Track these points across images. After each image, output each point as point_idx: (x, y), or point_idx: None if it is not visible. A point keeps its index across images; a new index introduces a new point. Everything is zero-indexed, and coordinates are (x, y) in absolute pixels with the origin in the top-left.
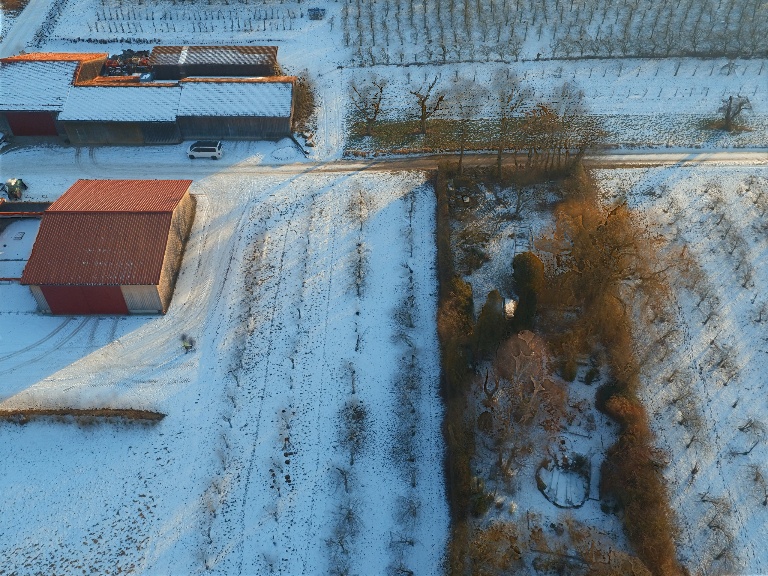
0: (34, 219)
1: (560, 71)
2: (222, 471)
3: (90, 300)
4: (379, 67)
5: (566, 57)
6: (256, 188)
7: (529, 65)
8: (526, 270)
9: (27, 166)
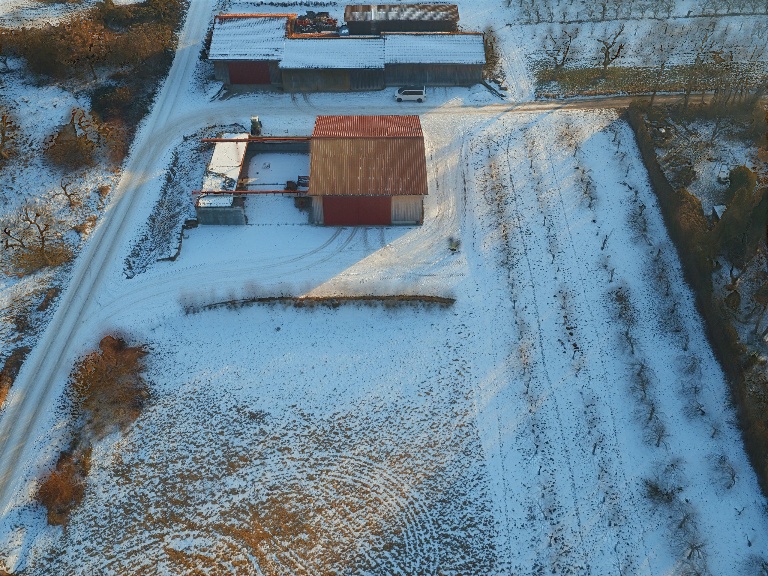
0: (273, 152)
1: (714, 25)
2: (518, 341)
3: (361, 211)
4: (544, 24)
5: (713, 14)
6: (467, 124)
7: (681, 21)
8: (744, 181)
9: (252, 109)
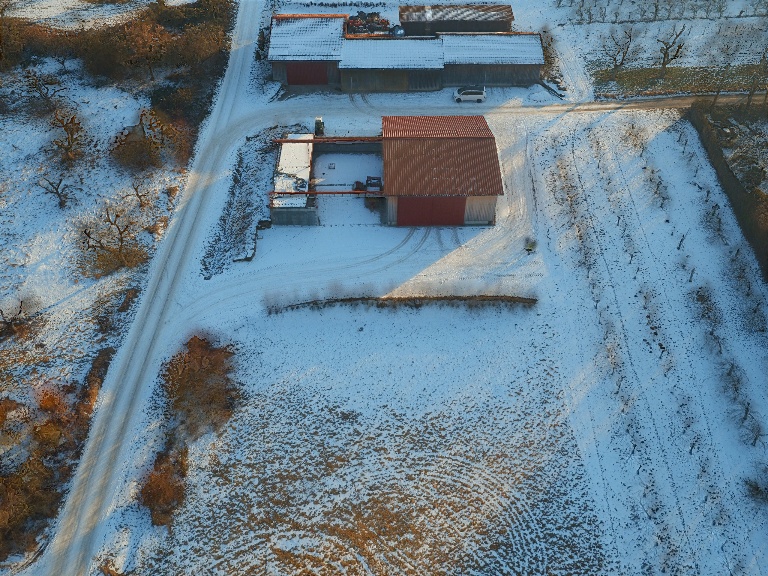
0: (337, 153)
1: (767, 25)
2: (603, 341)
3: (435, 212)
4: (596, 24)
5: (764, 14)
6: (530, 125)
7: (733, 21)
8: None
9: (312, 109)
